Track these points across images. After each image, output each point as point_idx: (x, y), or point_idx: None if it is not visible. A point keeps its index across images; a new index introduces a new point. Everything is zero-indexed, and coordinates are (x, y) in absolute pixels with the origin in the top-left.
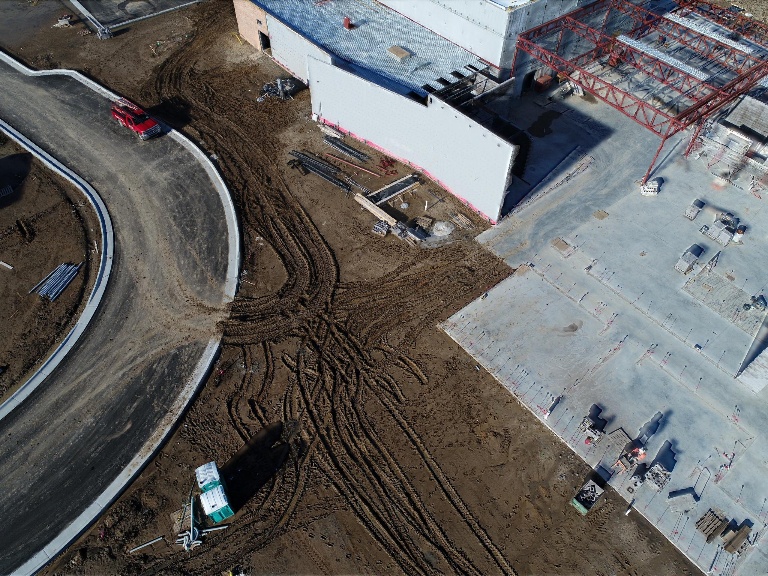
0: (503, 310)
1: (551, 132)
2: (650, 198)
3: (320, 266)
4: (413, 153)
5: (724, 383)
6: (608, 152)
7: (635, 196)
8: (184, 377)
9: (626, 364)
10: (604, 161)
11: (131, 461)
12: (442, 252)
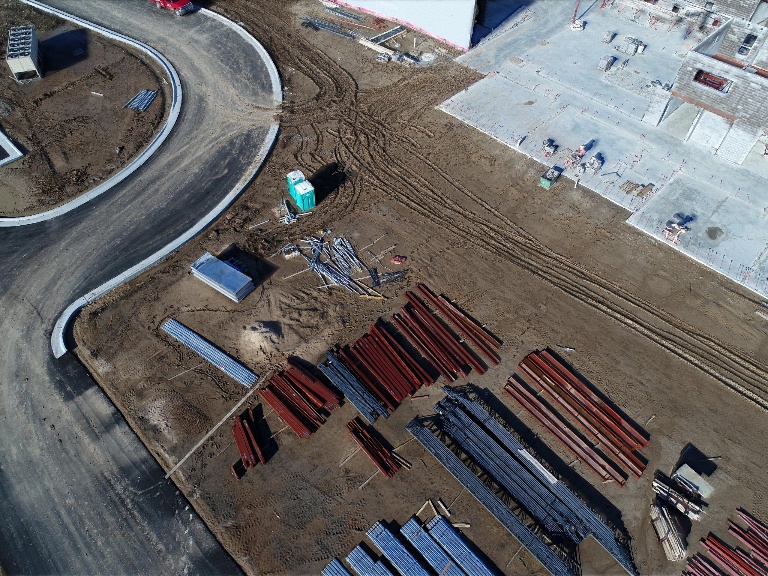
0: (480, 96)
1: None
2: (578, 33)
3: (342, 82)
4: (399, 10)
5: (634, 124)
6: (545, 8)
7: (567, 32)
8: (258, 145)
9: (569, 118)
10: (543, 13)
11: (234, 187)
12: (431, 69)
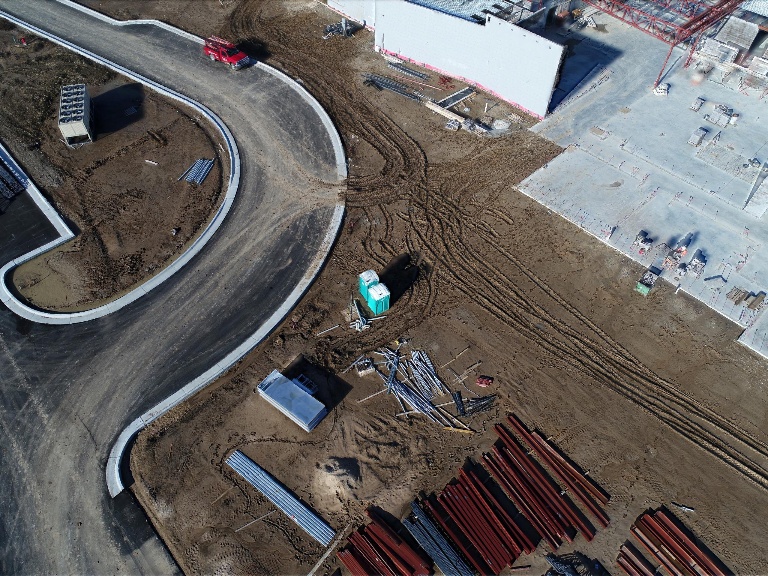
0: (562, 175)
1: (575, 54)
2: (662, 98)
3: (410, 153)
4: (469, 70)
5: (735, 213)
6: (623, 67)
7: (650, 97)
8: (323, 229)
9: (661, 205)
10: (621, 73)
11: (300, 282)
12: (505, 140)
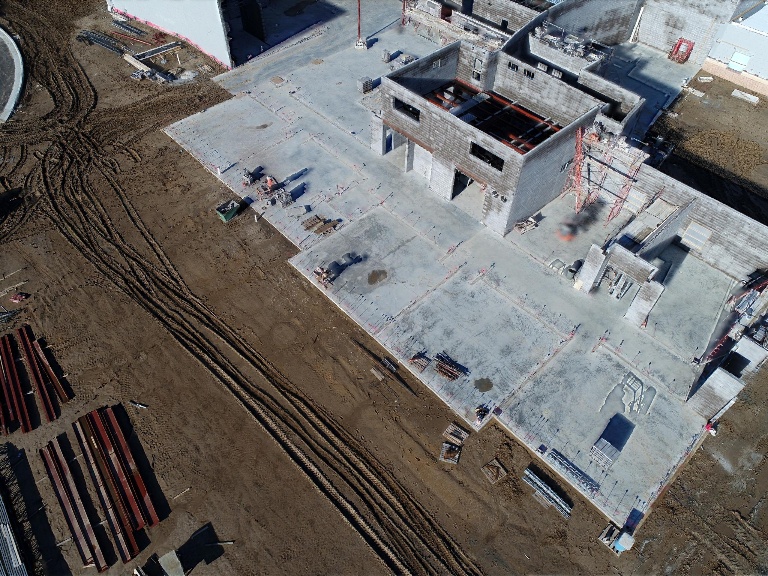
0: (215, 118)
1: (302, 13)
2: (362, 51)
3: (83, 100)
4: (176, 25)
5: (362, 151)
6: (342, 24)
7: (350, 50)
8: None
9: (294, 144)
10: (336, 30)
11: None
12: (182, 88)
